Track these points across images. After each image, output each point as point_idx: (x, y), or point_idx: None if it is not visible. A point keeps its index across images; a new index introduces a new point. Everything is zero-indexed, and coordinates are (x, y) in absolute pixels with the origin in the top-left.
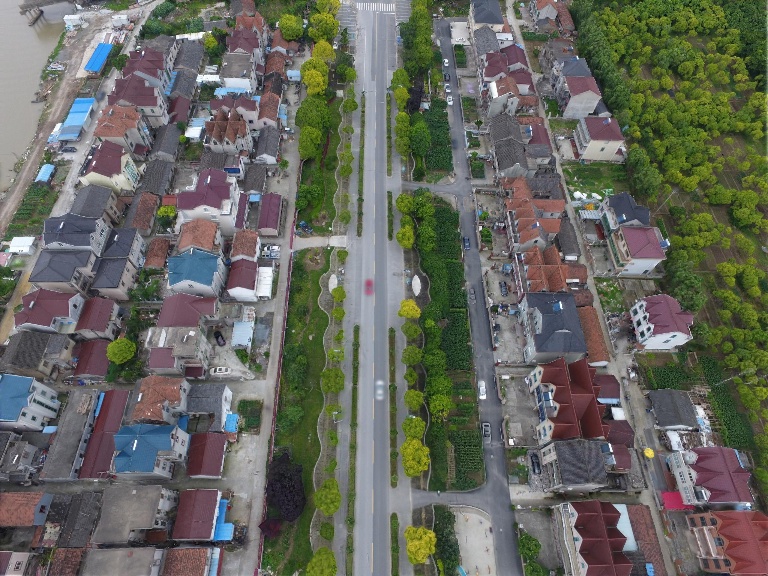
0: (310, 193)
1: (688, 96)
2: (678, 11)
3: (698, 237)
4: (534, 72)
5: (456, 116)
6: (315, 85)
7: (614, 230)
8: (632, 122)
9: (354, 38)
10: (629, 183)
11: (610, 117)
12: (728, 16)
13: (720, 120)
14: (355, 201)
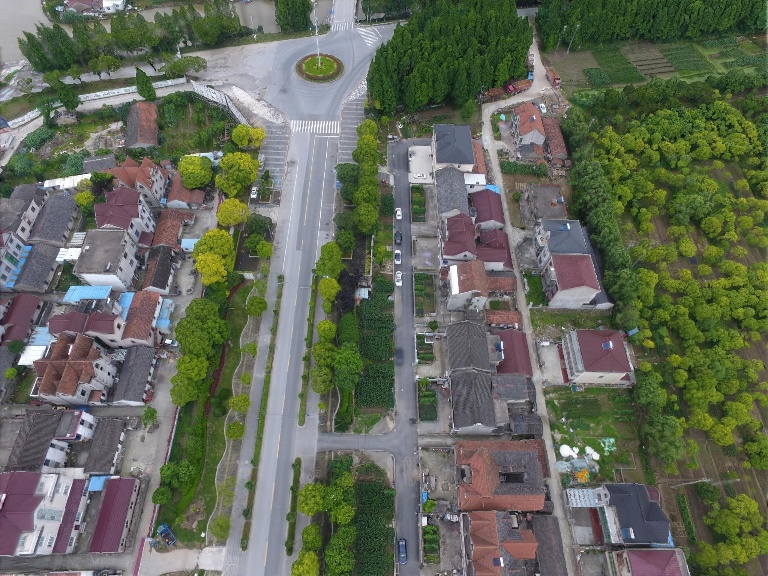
0: (178, 475)
1: (714, 264)
2: (699, 129)
3: (739, 548)
4: (513, 227)
5: (405, 305)
6: (211, 274)
7: (617, 543)
8: (642, 322)
9: (281, 178)
10: (638, 424)
11: (612, 308)
12: (762, 136)
13: (759, 311)
14: (247, 476)
